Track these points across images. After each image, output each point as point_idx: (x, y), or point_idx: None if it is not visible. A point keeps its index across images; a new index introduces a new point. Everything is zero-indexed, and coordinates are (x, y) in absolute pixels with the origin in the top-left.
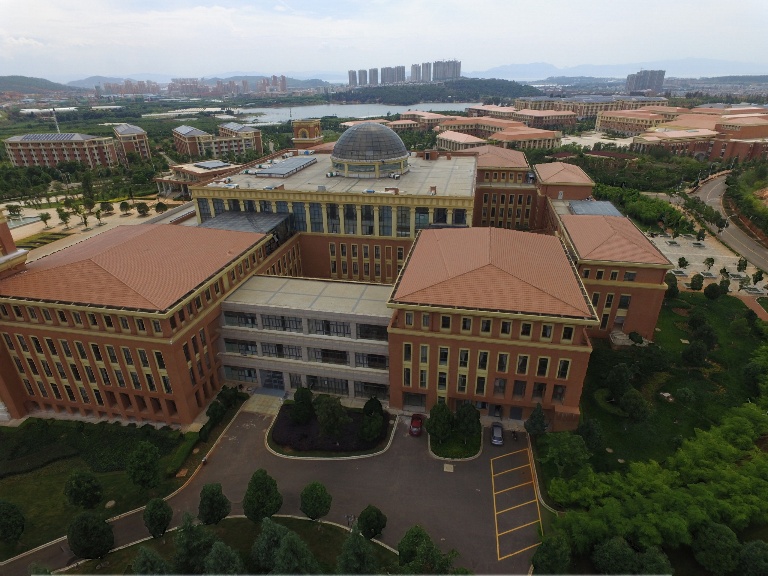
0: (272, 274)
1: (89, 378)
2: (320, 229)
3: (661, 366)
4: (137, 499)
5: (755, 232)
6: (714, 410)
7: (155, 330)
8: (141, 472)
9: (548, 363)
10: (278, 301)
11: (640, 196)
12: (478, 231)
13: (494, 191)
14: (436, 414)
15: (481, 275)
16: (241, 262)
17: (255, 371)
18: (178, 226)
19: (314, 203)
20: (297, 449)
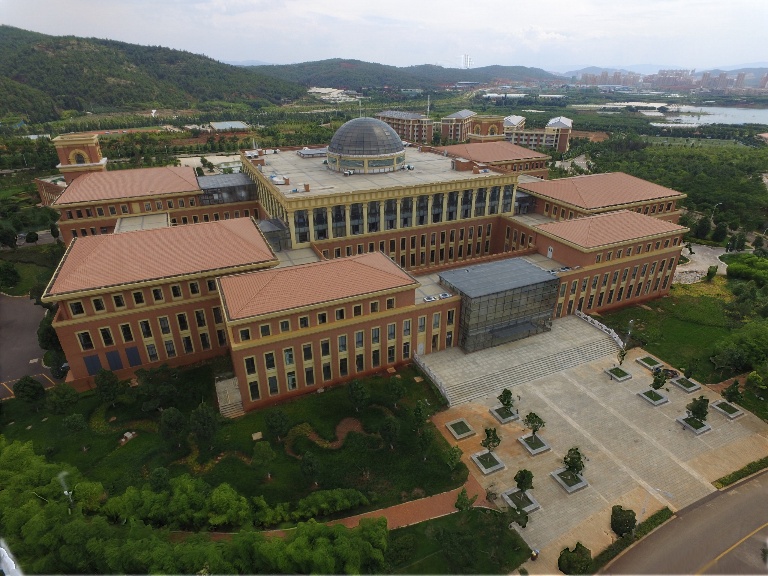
0: None
1: None
2: None
3: None
4: None
5: None
6: (107, 472)
7: None
8: None
9: None
10: (127, 228)
11: None
12: None
13: (515, 226)
14: None
15: None
16: (161, 201)
17: None
18: (168, 170)
19: None
20: None
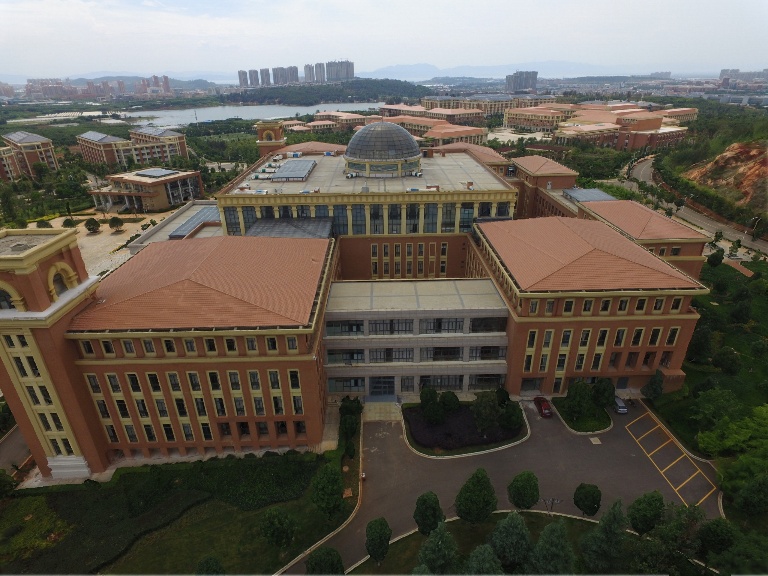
0: (334, 280)
1: (198, 412)
2: (362, 231)
3: (723, 325)
4: (317, 528)
5: (700, 209)
6: None
7: (288, 348)
8: (334, 497)
9: (660, 333)
10: (382, 305)
11: (596, 183)
12: (546, 221)
13: None
14: (580, 392)
15: (592, 259)
16: None
17: (364, 379)
18: (242, 237)
19: (357, 205)
20: (448, 448)
